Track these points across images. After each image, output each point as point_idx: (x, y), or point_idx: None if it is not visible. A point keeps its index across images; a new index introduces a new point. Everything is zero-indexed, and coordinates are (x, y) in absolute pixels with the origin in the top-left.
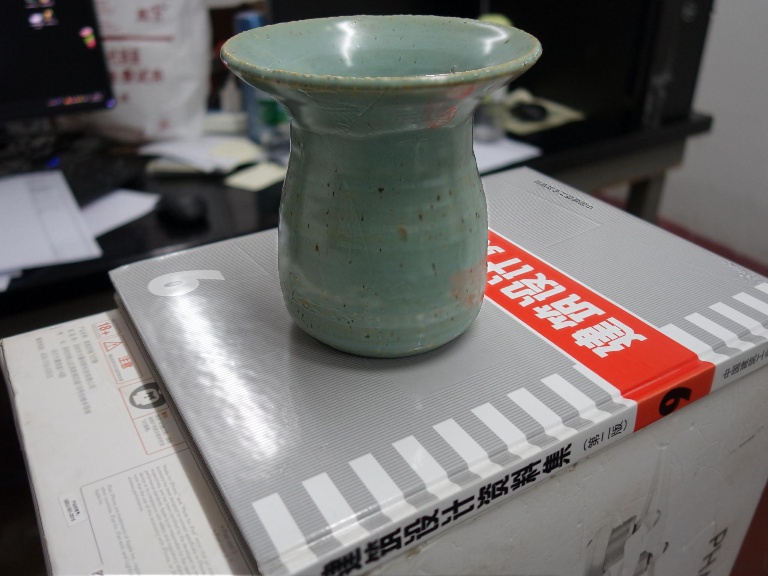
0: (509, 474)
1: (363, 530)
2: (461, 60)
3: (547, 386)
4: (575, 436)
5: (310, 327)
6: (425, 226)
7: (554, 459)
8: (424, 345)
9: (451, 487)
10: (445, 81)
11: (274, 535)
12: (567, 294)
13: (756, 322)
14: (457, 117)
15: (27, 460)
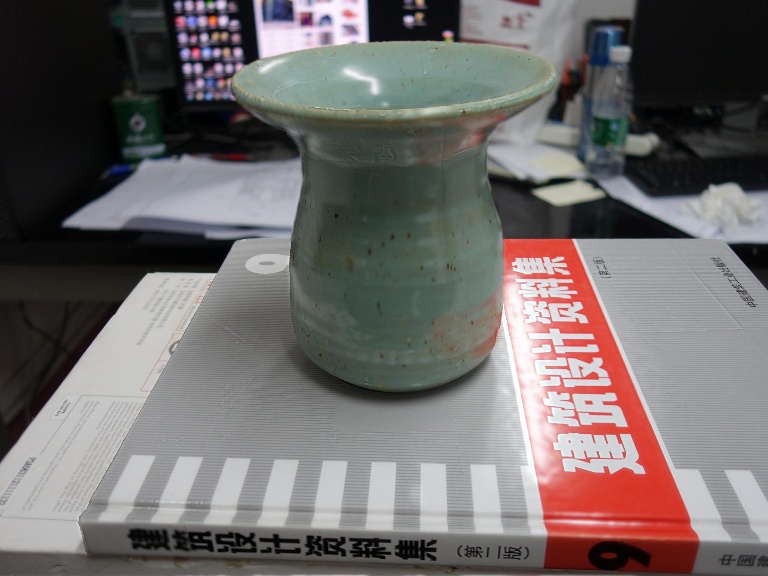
0: (346, 537)
1: (177, 517)
2: None
3: (470, 473)
4: (442, 534)
5: None
6: (373, 262)
7: (411, 547)
8: (373, 383)
9: (279, 520)
10: (345, 117)
11: (119, 486)
12: (605, 390)
13: None
14: (402, 157)
15: (76, 362)
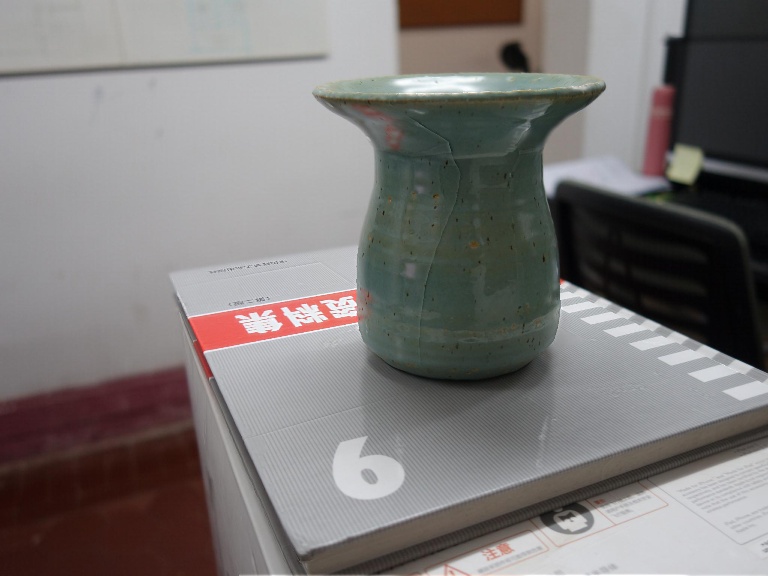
0: None
1: (735, 362)
2: None
3: None
4: None
5: (538, 346)
6: None
7: None
8: None
9: (675, 335)
10: None
11: (764, 391)
12: None
13: None
14: None
15: None
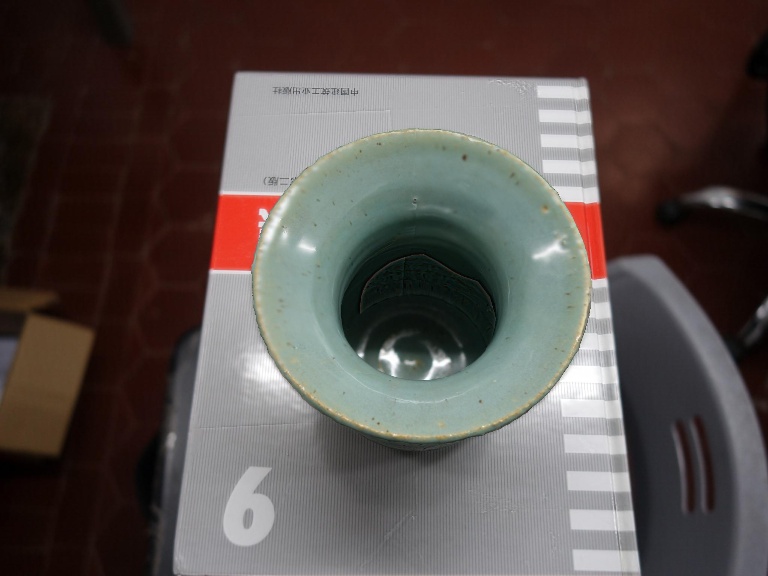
0: None
1: (628, 513)
2: (419, 190)
3: None
4: None
5: None
6: None
7: None
8: None
9: (619, 440)
10: None
11: (607, 568)
12: None
13: (574, 136)
14: None
15: None
